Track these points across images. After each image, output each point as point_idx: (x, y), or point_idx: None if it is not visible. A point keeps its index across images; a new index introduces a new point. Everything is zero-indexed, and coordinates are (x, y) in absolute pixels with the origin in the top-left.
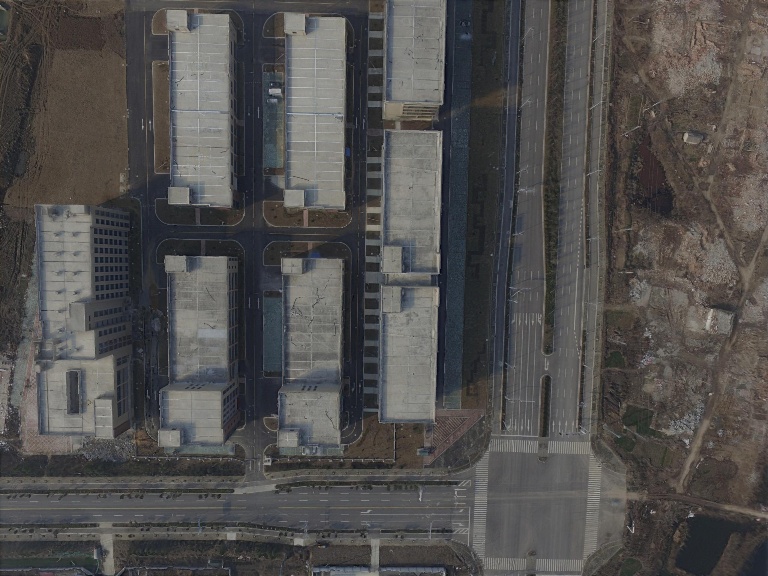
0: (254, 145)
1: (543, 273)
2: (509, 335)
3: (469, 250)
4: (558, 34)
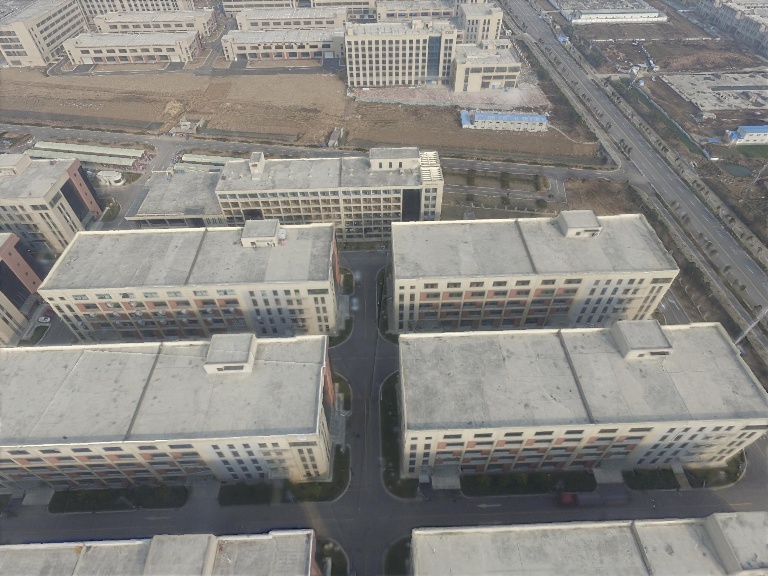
0: None
1: None
2: None
3: None
4: None
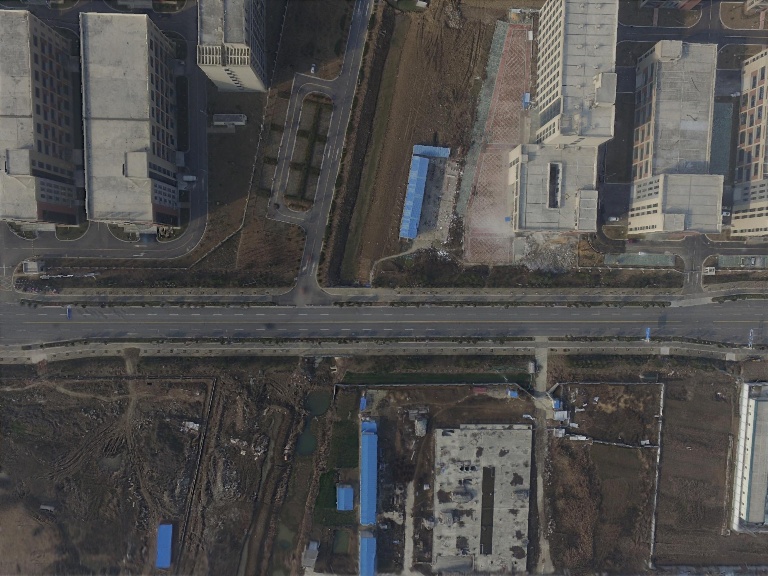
0: None
1: None
2: None
3: None
4: None
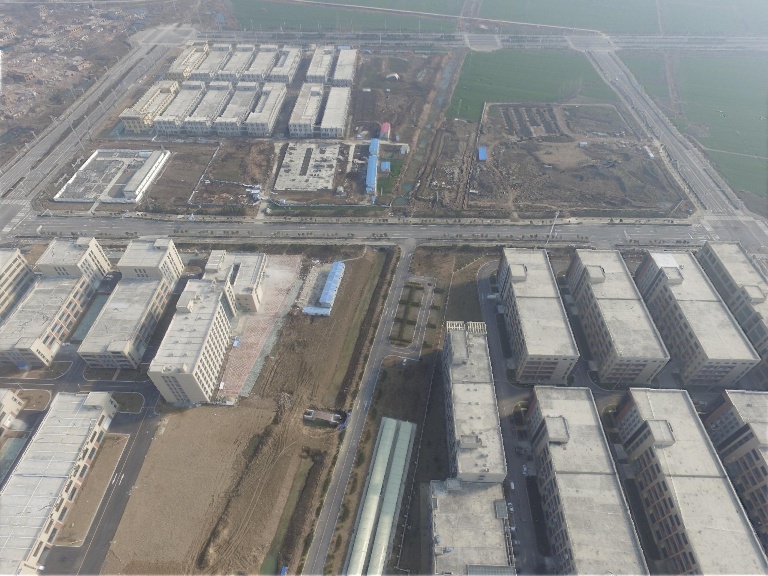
0: None
1: None
2: None
3: None
4: None
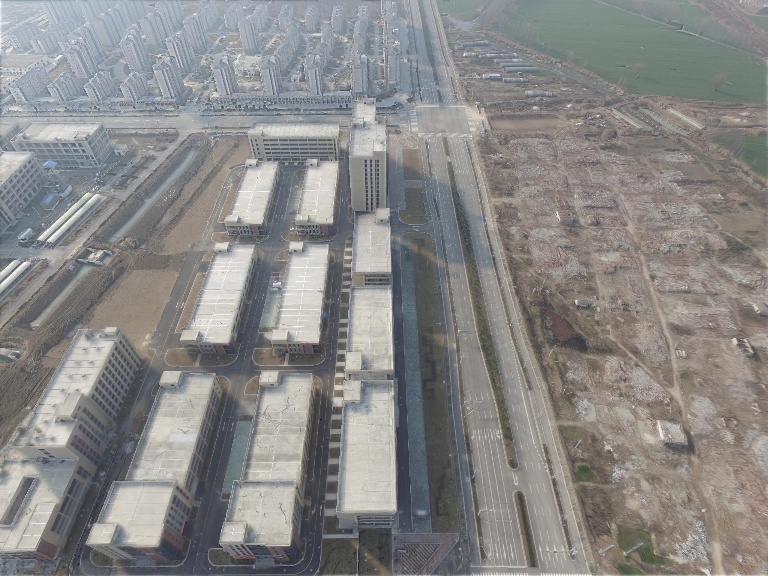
0: (255, 314)
1: (492, 395)
2: (471, 450)
3: (424, 378)
4: (469, 254)
